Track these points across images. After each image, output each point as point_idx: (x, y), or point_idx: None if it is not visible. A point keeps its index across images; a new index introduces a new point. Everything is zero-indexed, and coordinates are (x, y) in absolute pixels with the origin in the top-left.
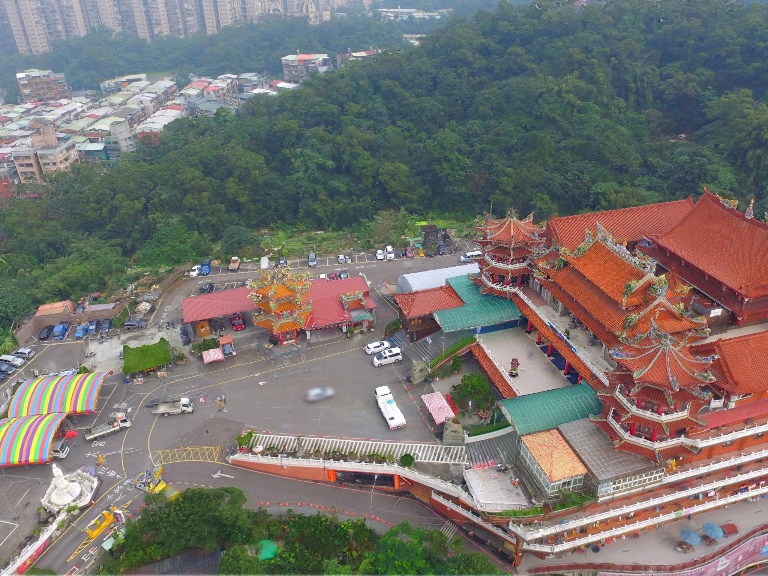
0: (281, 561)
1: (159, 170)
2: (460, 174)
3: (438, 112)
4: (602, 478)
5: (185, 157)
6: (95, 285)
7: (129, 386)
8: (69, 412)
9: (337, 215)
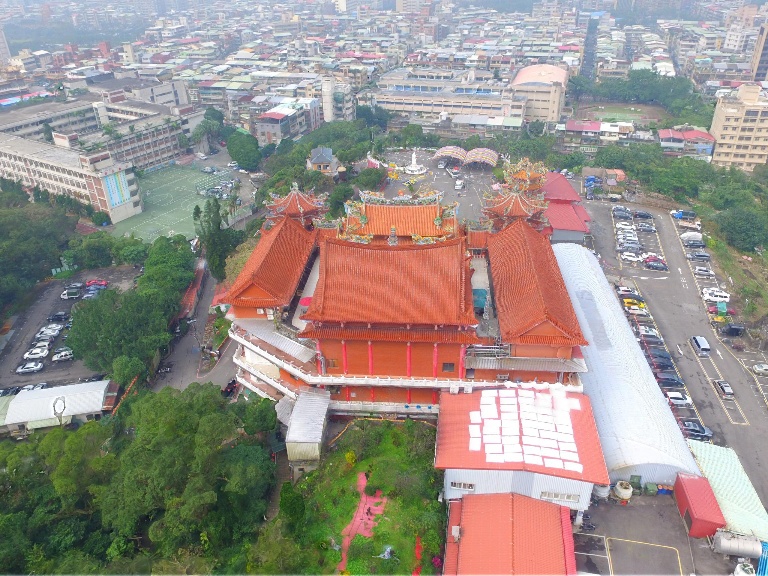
0: None
1: None
2: None
3: None
4: None
5: None
6: (641, 177)
7: (489, 177)
8: (461, 159)
9: None
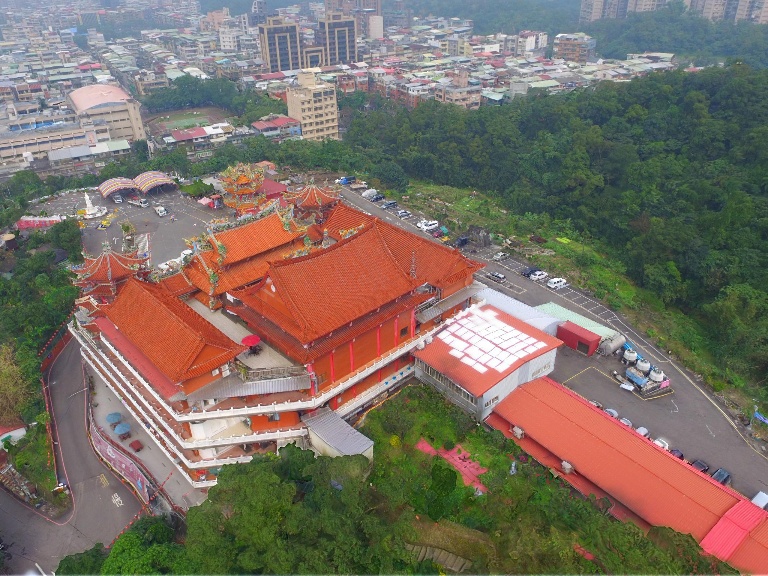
0: (63, 274)
1: (452, 117)
2: (632, 208)
3: (714, 141)
4: (75, 313)
5: (475, 113)
6: (290, 161)
7: (178, 196)
8: (138, 188)
9: (524, 202)
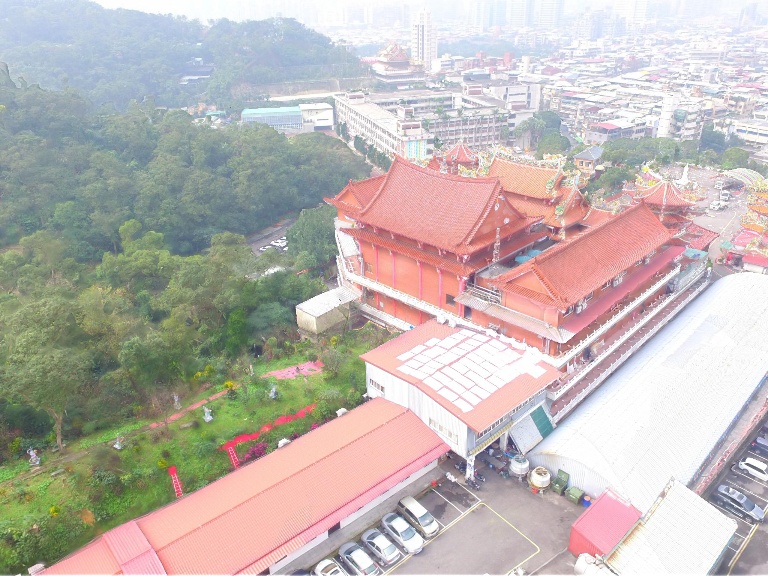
0: None
1: None
2: None
3: None
4: None
5: None
6: None
7: None
8: (745, 182)
9: None
